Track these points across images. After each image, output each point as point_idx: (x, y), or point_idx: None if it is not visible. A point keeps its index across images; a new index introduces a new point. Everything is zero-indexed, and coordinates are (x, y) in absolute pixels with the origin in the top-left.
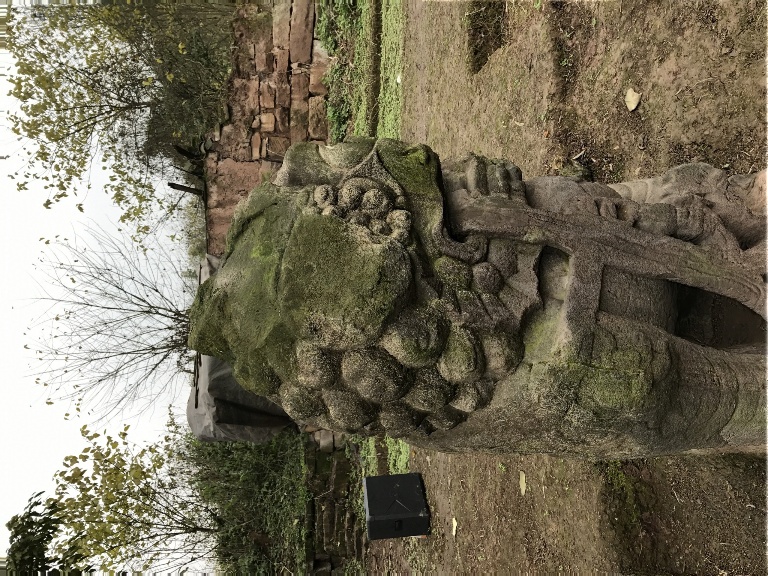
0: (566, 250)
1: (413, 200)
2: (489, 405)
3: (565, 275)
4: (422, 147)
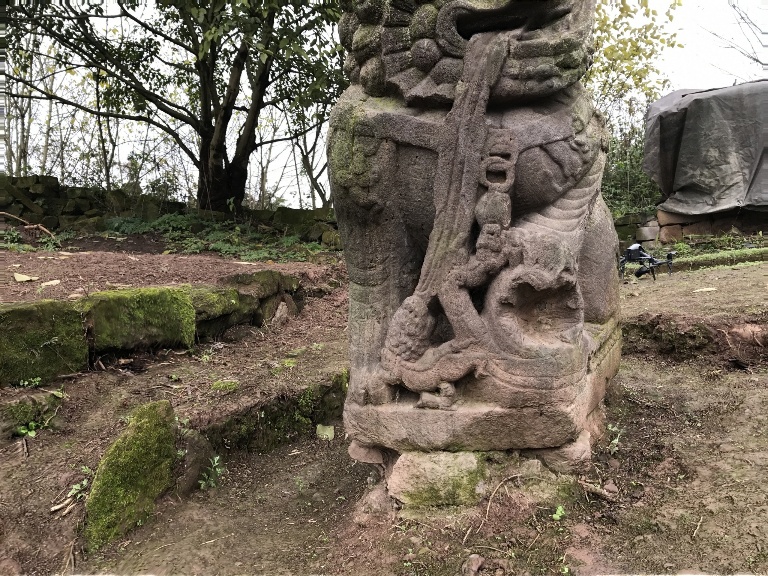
0: None
1: None
2: None
3: None
4: None
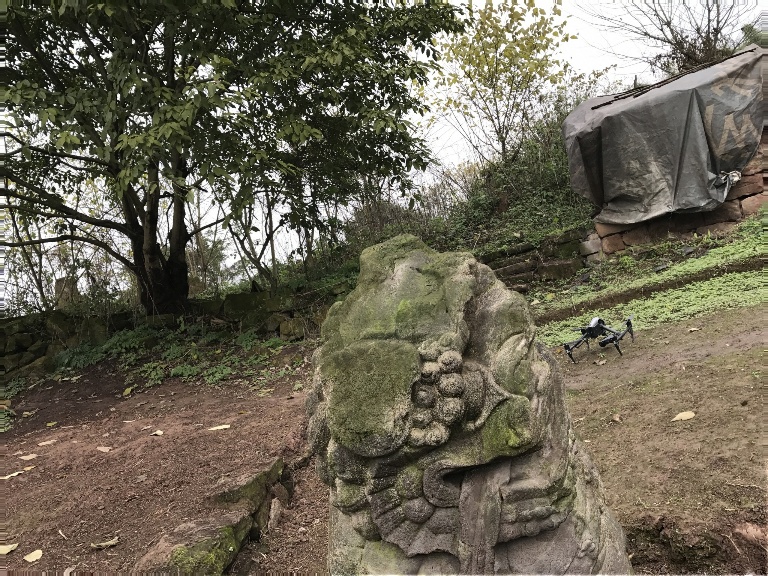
0: None
1: (476, 436)
2: None
3: None
4: (524, 441)
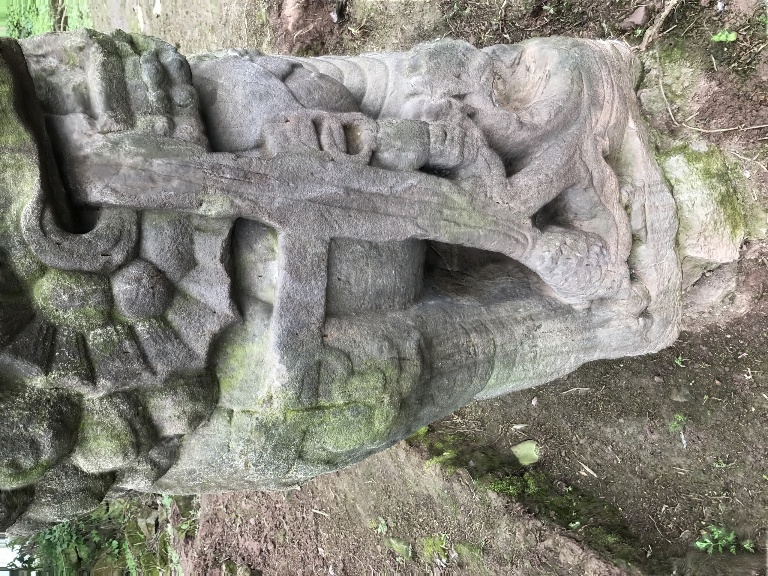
0: (271, 225)
1: None
2: (176, 465)
3: (273, 259)
4: None
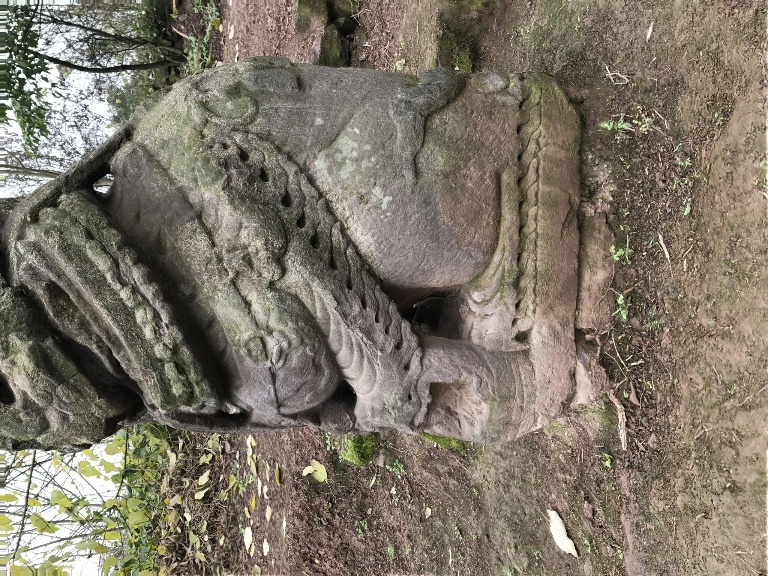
0: None
1: None
2: None
3: None
4: None
